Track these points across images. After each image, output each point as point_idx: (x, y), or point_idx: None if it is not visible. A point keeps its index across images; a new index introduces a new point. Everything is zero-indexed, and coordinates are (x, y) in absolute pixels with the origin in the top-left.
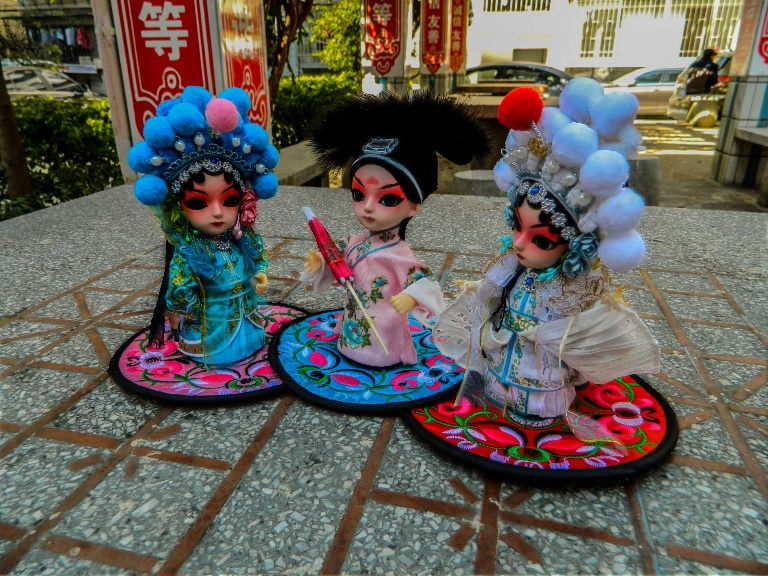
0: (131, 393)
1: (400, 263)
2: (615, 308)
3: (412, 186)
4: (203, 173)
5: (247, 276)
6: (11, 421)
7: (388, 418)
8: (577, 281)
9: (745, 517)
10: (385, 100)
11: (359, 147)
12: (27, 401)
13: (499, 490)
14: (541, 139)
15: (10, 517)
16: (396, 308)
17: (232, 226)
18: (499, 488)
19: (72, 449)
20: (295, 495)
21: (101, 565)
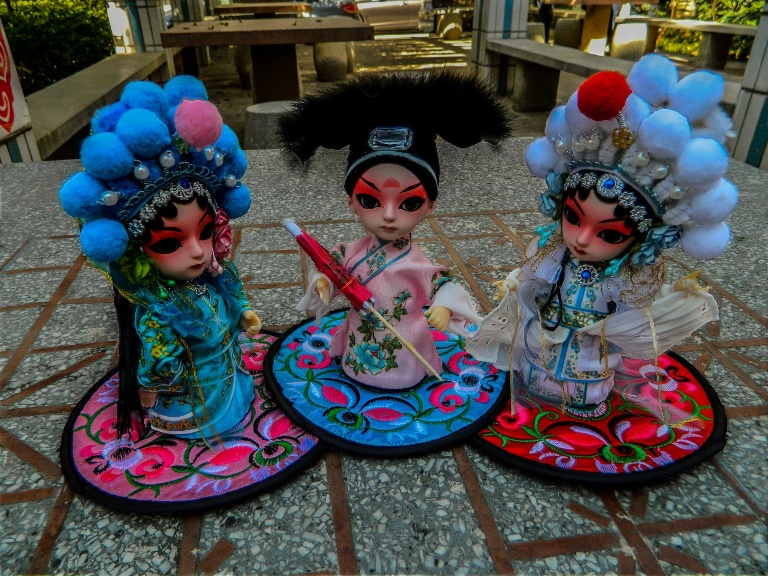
0: (125, 511)
1: (425, 272)
2: (693, 294)
3: (433, 183)
4: (172, 203)
5: (229, 318)
6: None
7: (456, 449)
8: (643, 270)
9: None
10: (394, 82)
11: (336, 136)
12: None
13: (618, 501)
14: (629, 130)
15: None
16: (438, 326)
17: (209, 263)
18: (616, 499)
19: None
20: None
21: None
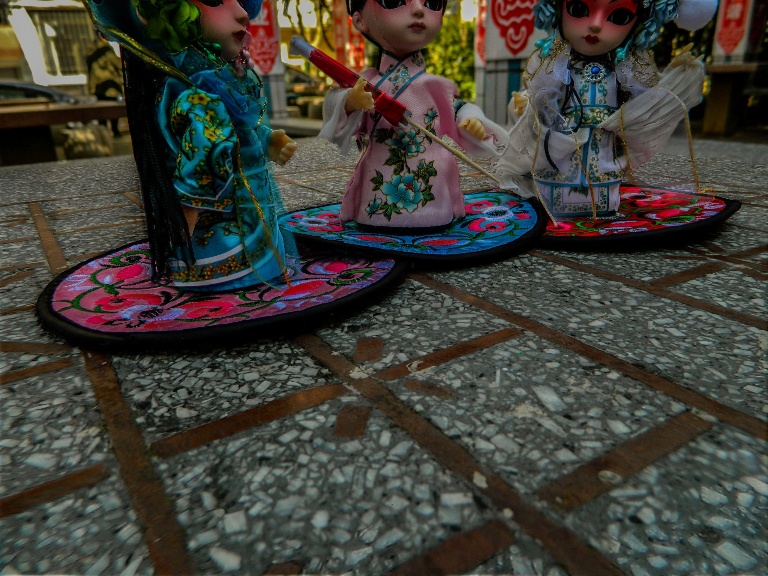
0: (203, 351)
1: (450, 86)
2: (690, 66)
3: None
4: None
5: None
6: (48, 476)
7: (530, 251)
8: (643, 55)
9: None
10: None
11: None
12: (6, 445)
13: (697, 249)
14: None
15: (425, 533)
16: (480, 131)
17: None
18: (694, 249)
19: (287, 426)
20: (621, 313)
21: (668, 459)
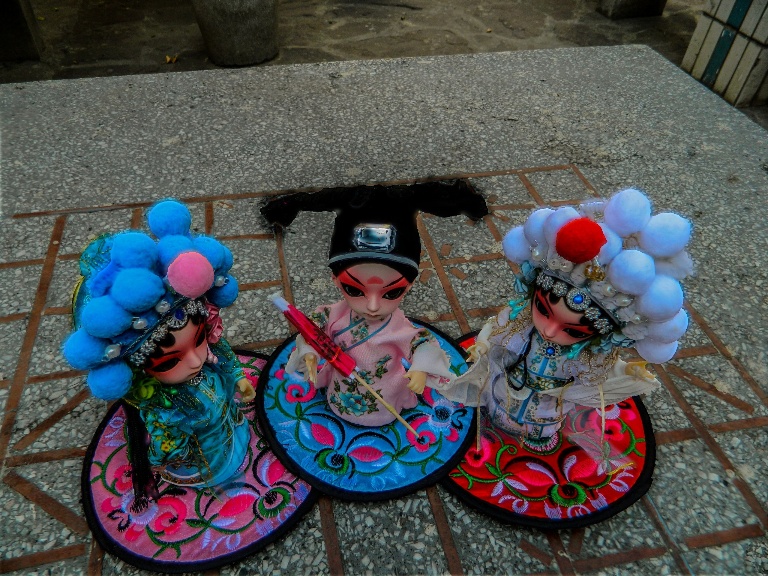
0: None
1: (405, 341)
2: (641, 379)
3: (415, 271)
4: (170, 333)
5: (225, 388)
6: None
7: (430, 488)
8: (601, 353)
9: (713, 484)
10: (379, 191)
11: None
12: None
13: (560, 539)
14: (601, 270)
15: None
16: (416, 391)
17: None
18: (558, 536)
19: None
20: None
21: None
